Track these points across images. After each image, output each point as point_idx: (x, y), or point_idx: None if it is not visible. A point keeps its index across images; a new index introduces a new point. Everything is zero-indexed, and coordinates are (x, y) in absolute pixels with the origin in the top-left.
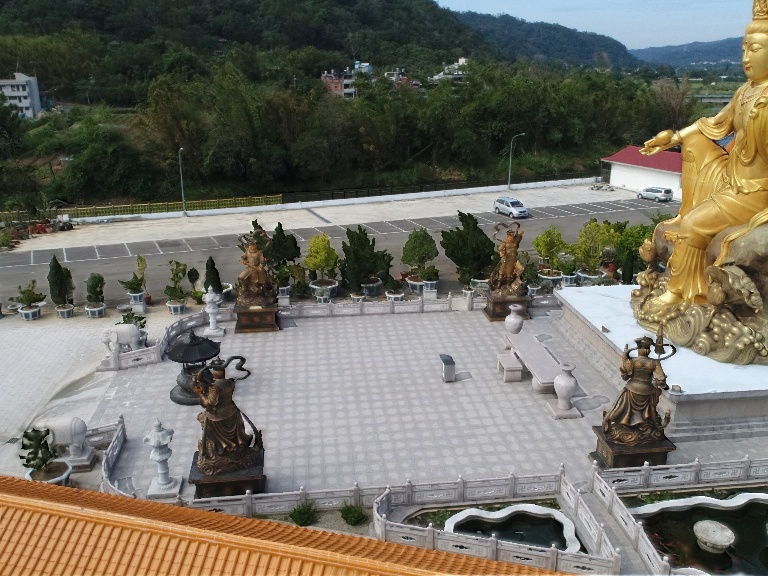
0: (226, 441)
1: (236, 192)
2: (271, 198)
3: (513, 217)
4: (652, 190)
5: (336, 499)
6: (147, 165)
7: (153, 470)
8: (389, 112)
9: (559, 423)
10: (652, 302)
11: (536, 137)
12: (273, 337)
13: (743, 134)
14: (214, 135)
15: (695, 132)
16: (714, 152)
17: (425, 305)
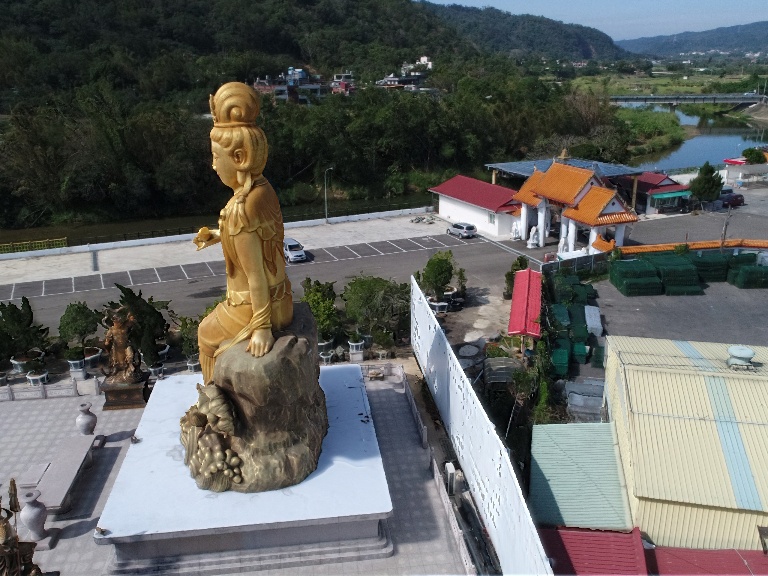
0: None
1: (101, 217)
2: (54, 241)
3: (290, 261)
4: (457, 226)
5: None
6: (4, 191)
7: None
8: None
9: None
10: None
11: (429, 152)
12: None
13: None
14: (71, 160)
15: None
16: None
17: (48, 391)
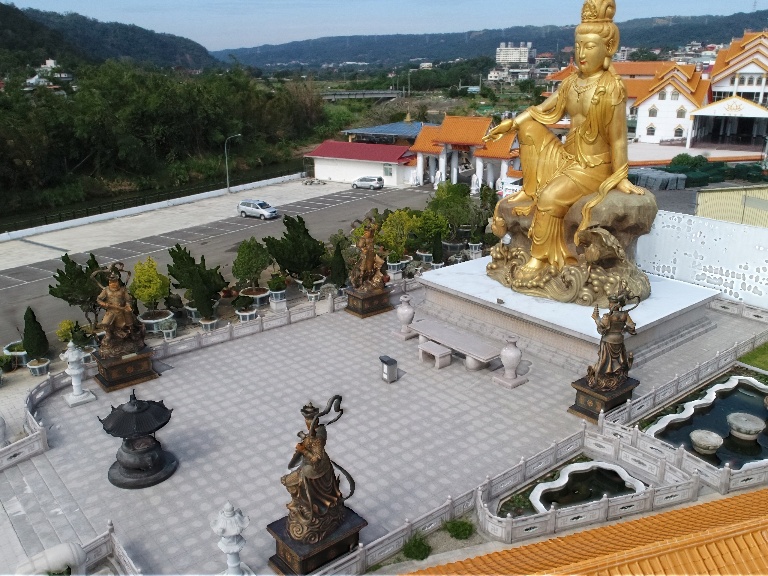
0: (328, 498)
1: None
2: None
3: (265, 219)
4: (366, 179)
5: (435, 520)
6: None
7: (195, 571)
8: (36, 121)
9: (518, 391)
10: (523, 270)
11: (197, 139)
12: (160, 385)
13: (583, 118)
14: None
15: (528, 119)
16: (549, 135)
17: (292, 316)
